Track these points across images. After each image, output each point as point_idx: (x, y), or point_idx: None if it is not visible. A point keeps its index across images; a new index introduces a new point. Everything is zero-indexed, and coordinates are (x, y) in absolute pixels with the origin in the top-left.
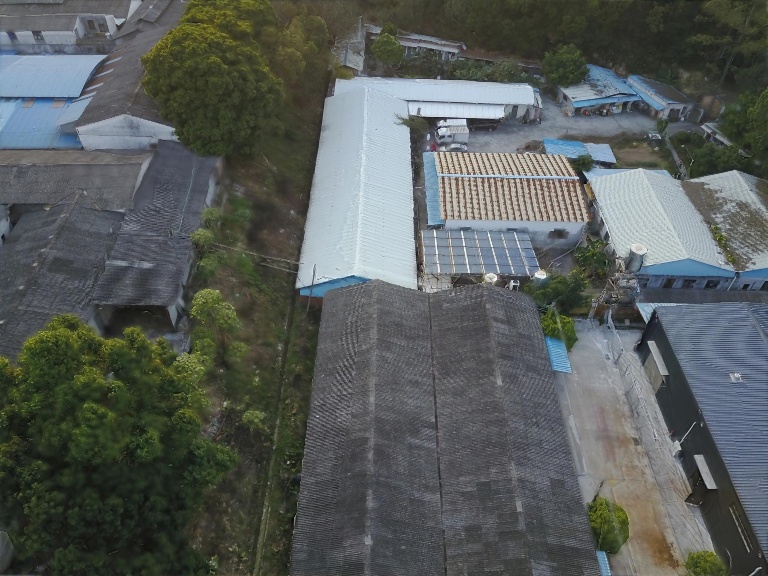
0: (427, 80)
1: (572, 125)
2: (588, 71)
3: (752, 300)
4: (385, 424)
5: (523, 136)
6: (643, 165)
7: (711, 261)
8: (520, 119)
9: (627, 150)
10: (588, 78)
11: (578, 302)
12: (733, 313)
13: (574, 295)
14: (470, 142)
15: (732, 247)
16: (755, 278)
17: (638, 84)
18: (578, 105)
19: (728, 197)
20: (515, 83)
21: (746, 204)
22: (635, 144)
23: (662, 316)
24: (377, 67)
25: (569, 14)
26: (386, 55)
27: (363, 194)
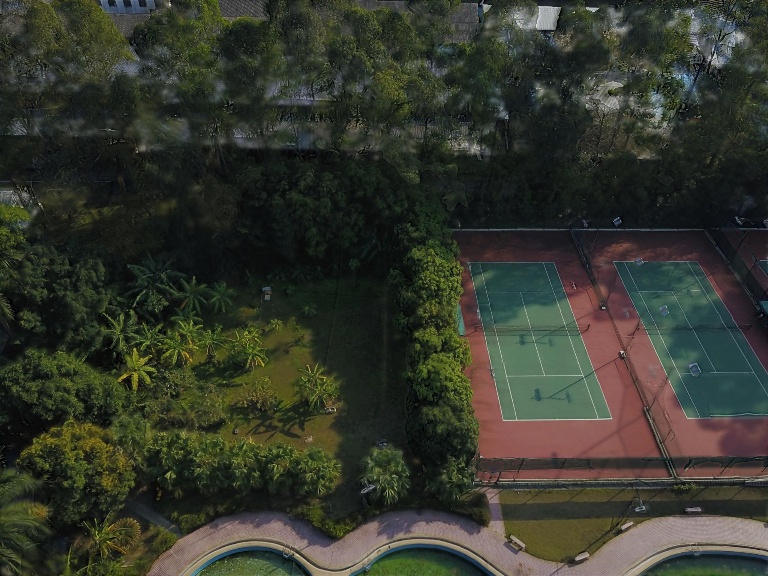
0: None
1: None
2: None
3: None
4: (392, 5)
5: None
6: None
7: None
8: None
9: None
10: None
11: None
12: None
13: None
14: None
15: None
16: None
17: None
18: None
19: None
20: None
21: None
22: None
23: None
24: None
25: None
26: None
27: (556, 8)
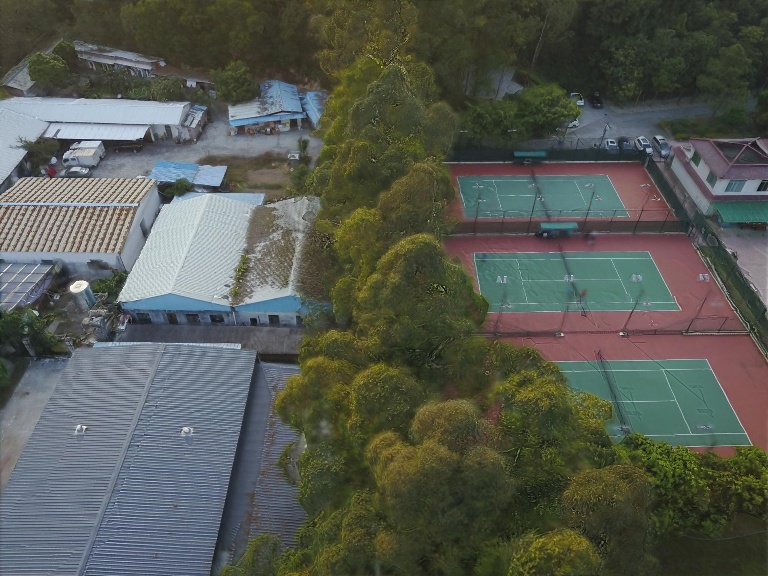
0: (85, 100)
1: (227, 145)
2: (269, 88)
3: (240, 336)
4: None
5: (166, 157)
6: (265, 187)
7: (201, 295)
8: (175, 139)
9: (262, 171)
10: (264, 95)
11: (45, 341)
12: (142, 356)
13: (36, 334)
14: (104, 164)
15: (247, 279)
16: (255, 312)
17: (311, 101)
18: (235, 124)
19: (282, 224)
20: (177, 102)
21: (290, 232)
22: (273, 165)
23: (72, 359)
24: (68, 85)
25: (235, 30)
26: (37, 75)
27: None
